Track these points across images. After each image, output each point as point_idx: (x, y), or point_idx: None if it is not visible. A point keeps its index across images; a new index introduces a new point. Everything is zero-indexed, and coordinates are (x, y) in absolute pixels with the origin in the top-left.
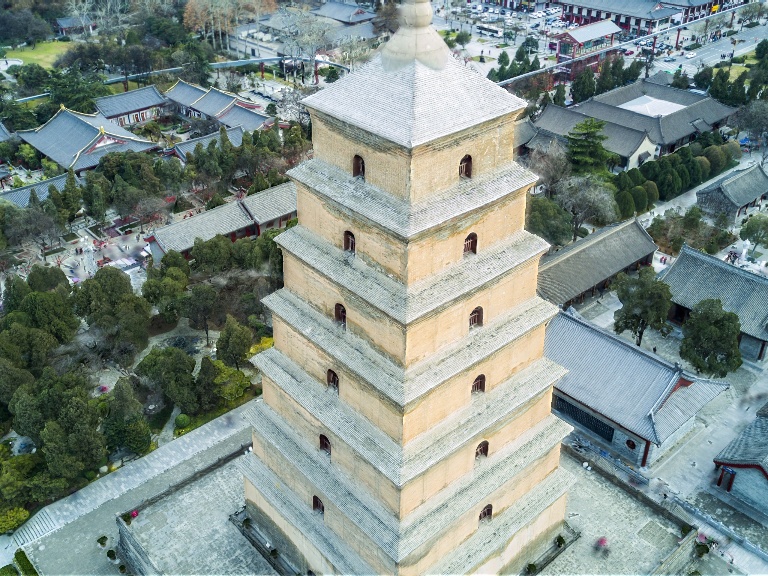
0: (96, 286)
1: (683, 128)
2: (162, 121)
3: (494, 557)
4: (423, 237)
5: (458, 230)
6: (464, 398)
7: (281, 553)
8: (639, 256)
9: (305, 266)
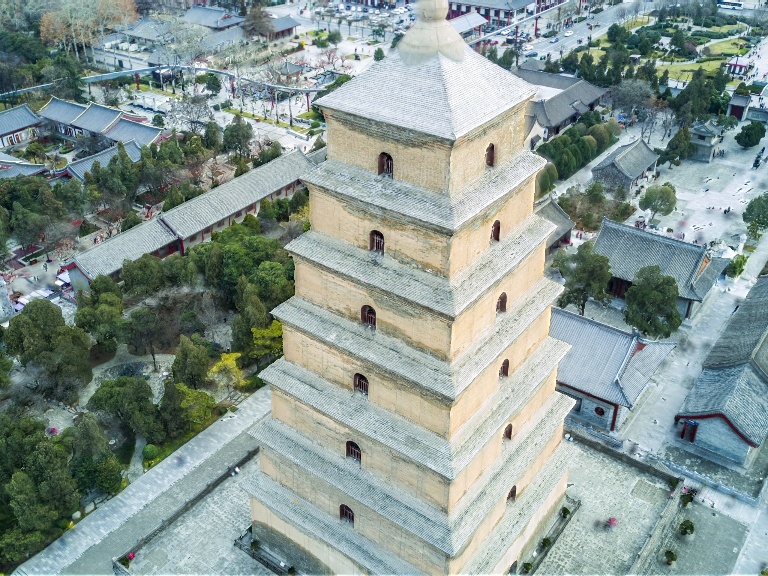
0: (27, 322)
1: (565, 110)
2: (40, 142)
3: (518, 537)
4: (462, 228)
5: (487, 219)
6: (493, 384)
7: (299, 570)
8: (560, 234)
9: (324, 271)
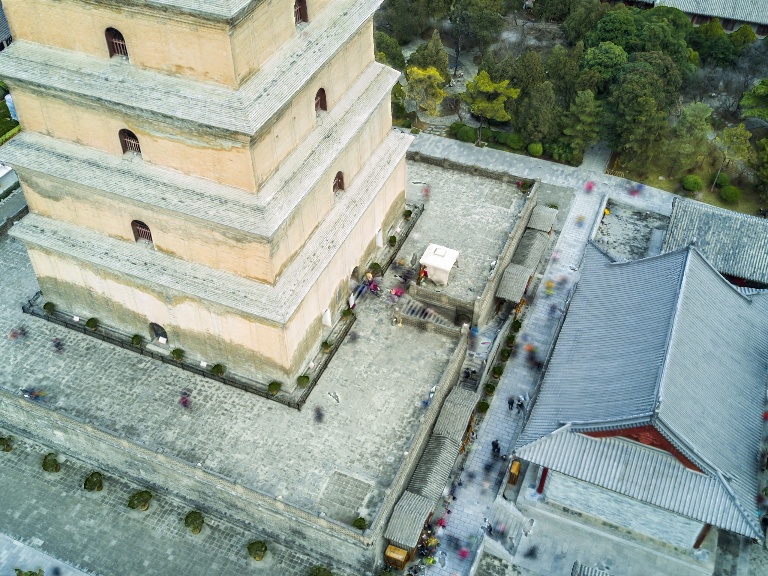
0: None
1: None
2: None
3: (158, 298)
4: None
5: None
6: (94, 44)
7: None
8: None
9: None
